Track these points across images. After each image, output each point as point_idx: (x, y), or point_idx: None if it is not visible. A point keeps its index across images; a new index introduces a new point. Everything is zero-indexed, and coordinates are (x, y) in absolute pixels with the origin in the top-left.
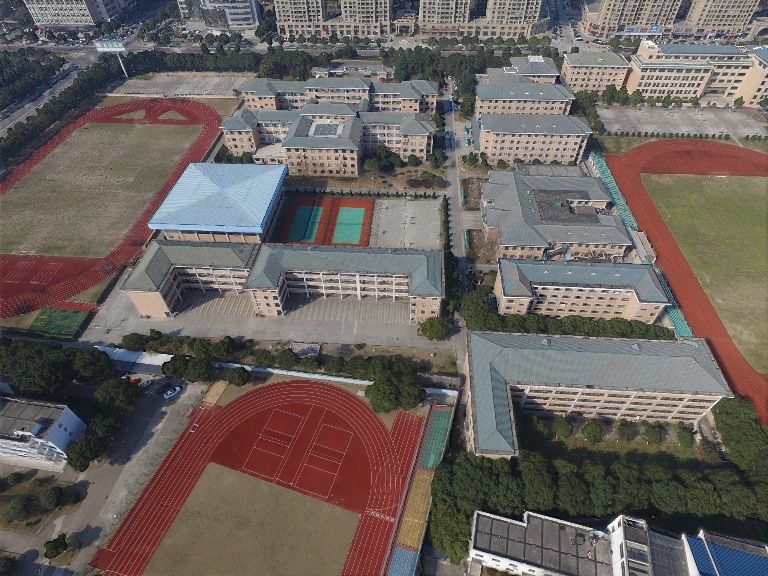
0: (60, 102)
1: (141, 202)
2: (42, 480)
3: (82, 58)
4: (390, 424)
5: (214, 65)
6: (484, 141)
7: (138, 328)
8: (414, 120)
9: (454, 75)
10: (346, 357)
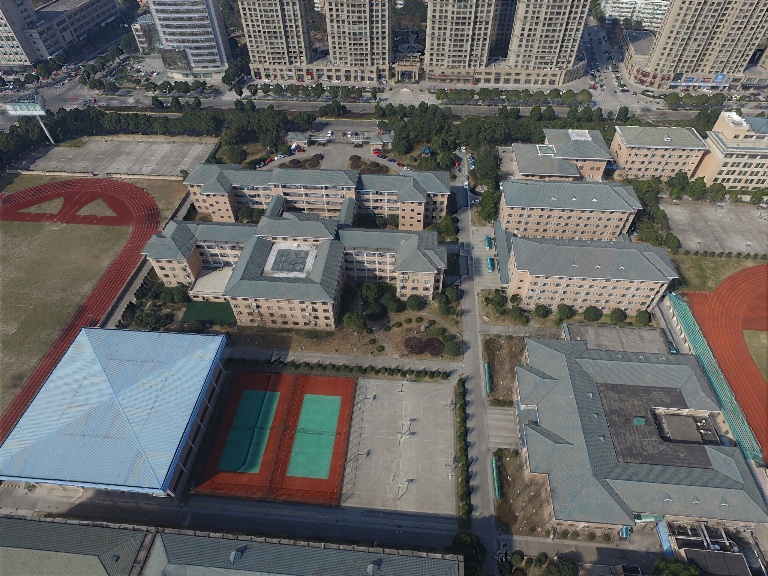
0: None
1: (16, 377)
2: None
3: (6, 112)
4: None
5: (163, 128)
6: (517, 281)
7: None
8: (416, 250)
9: (469, 146)
10: None
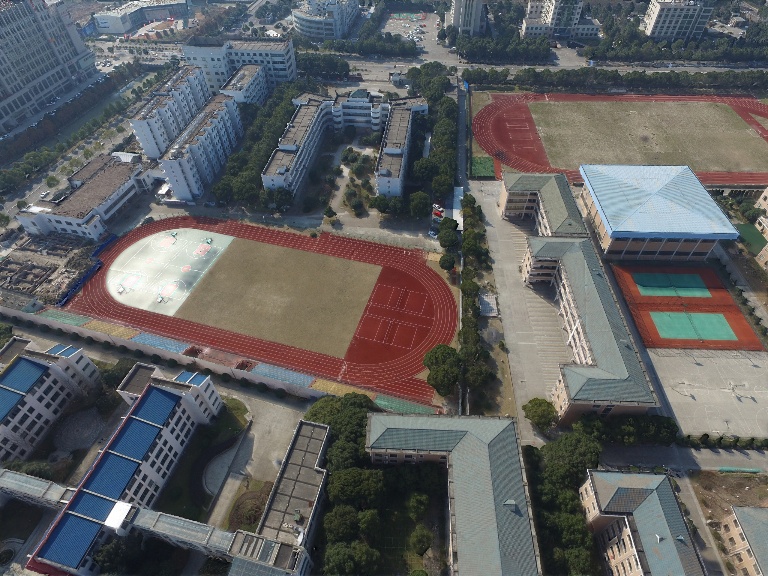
0: (734, 76)
1: None
2: (369, 198)
3: None
4: (421, 377)
5: None
6: None
7: (487, 204)
8: None
9: None
10: (488, 338)
